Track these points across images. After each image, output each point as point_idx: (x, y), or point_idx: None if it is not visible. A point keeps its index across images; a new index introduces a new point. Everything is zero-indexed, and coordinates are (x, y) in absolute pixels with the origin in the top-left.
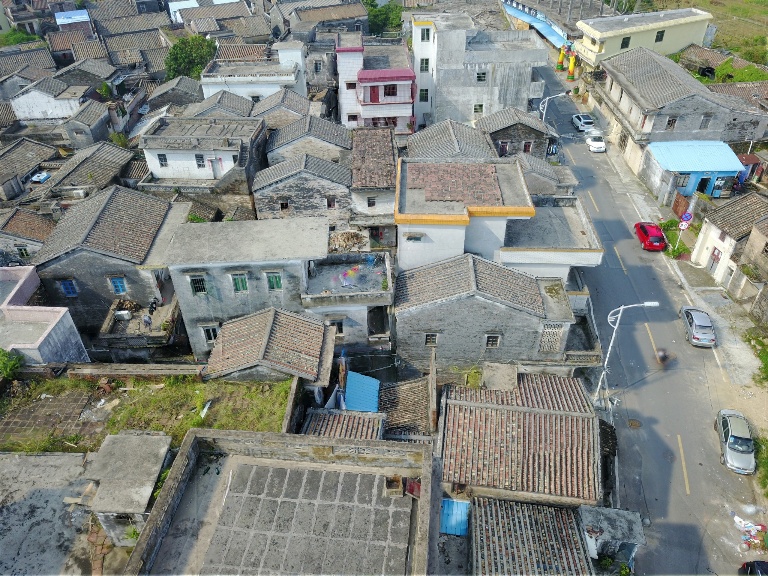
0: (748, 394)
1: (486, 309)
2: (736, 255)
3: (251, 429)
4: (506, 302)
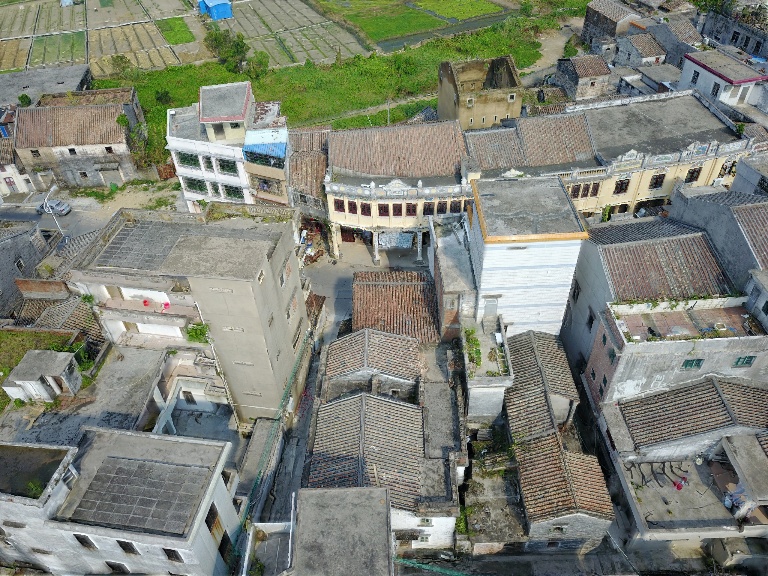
0: (107, 208)
1: (4, 249)
2: (21, 171)
3: (28, 349)
4: (8, 237)
